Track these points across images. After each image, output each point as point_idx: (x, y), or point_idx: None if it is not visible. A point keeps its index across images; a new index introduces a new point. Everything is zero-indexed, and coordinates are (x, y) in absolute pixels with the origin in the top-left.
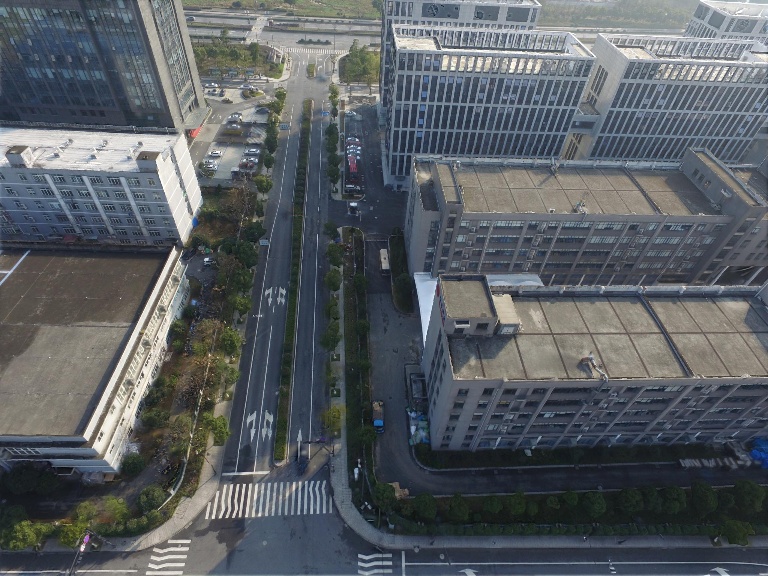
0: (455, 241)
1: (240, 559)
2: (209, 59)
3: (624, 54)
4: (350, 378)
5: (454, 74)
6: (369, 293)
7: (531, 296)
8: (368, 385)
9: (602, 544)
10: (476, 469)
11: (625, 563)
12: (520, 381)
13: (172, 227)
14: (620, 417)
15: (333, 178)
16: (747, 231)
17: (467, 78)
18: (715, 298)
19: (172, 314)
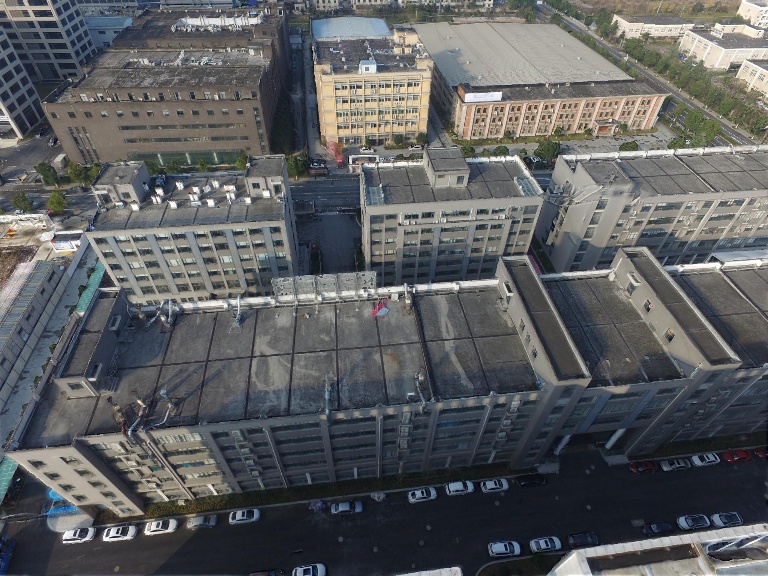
0: None
1: None
2: None
3: None
4: None
5: None
6: None
7: None
8: None
9: None
10: None
11: None
12: None
13: None
14: None
15: None
16: None
17: None
18: None
19: None
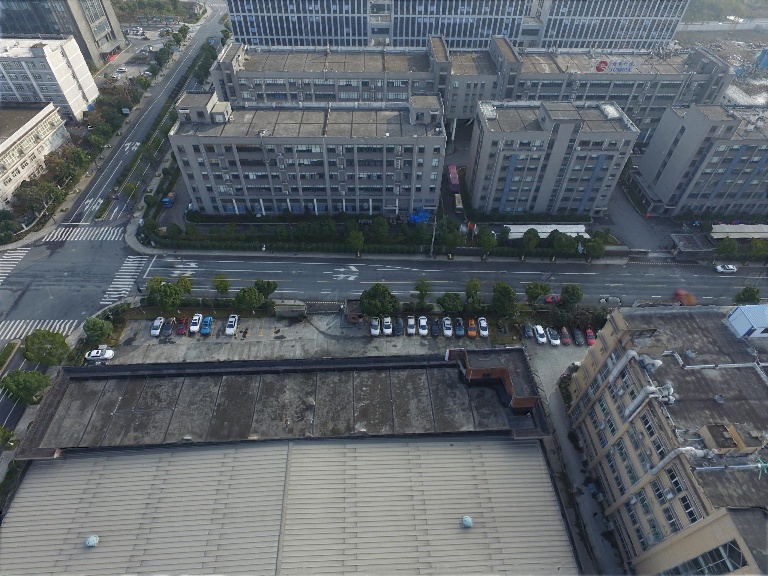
0: (243, 97)
1: (56, 255)
2: (142, 11)
3: None
4: (161, 183)
5: None
6: None
7: None
8: (172, 187)
9: (283, 255)
10: (222, 224)
11: (293, 263)
12: (207, 136)
13: (65, 104)
14: (301, 180)
15: (199, 80)
16: (447, 84)
17: None
18: (379, 110)
19: (51, 148)
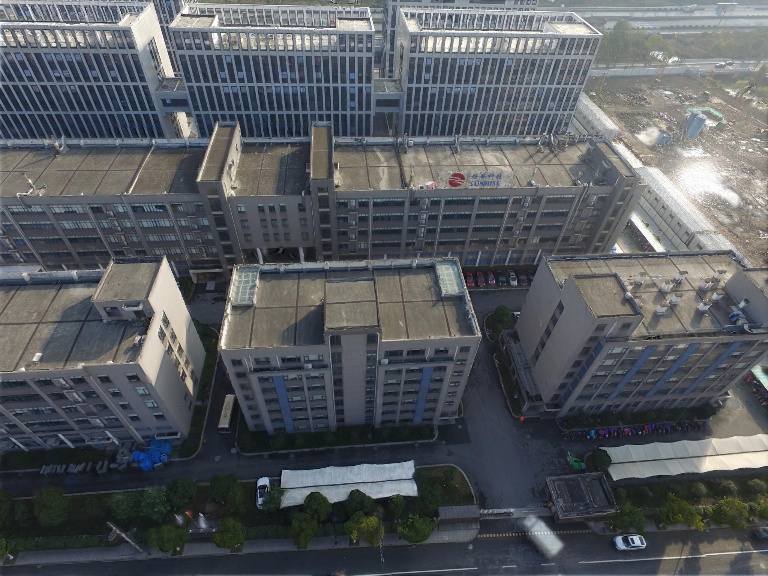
0: None
1: None
2: None
3: (172, 23)
4: None
5: None
6: None
7: None
8: None
9: None
10: None
11: None
12: None
13: None
14: None
15: None
16: (224, 210)
17: None
18: (67, 285)
19: None
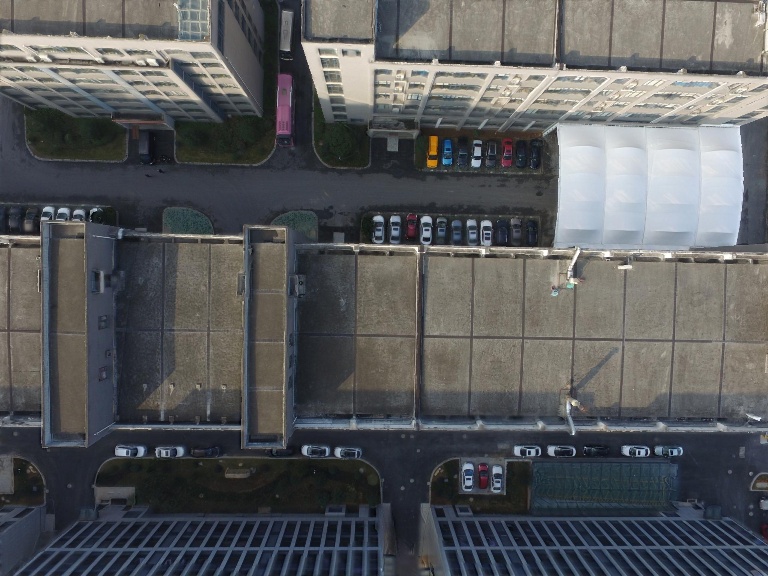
0: None
1: None
2: None
3: None
4: None
5: None
6: None
7: None
8: None
9: None
10: None
11: None
12: None
13: None
14: None
15: None
16: None
17: None
18: (444, 58)
19: None
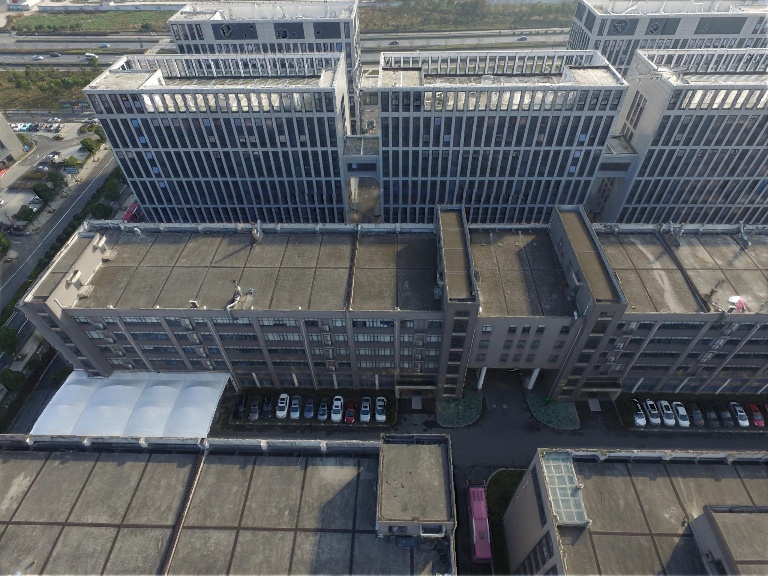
0: (91, 337)
1: None
2: None
3: (378, 81)
4: None
5: (165, 115)
6: (38, 389)
7: (48, 448)
8: None
9: None
10: None
11: None
12: None
13: None
14: None
15: None
16: (468, 331)
17: (184, 119)
18: (313, 458)
19: None
